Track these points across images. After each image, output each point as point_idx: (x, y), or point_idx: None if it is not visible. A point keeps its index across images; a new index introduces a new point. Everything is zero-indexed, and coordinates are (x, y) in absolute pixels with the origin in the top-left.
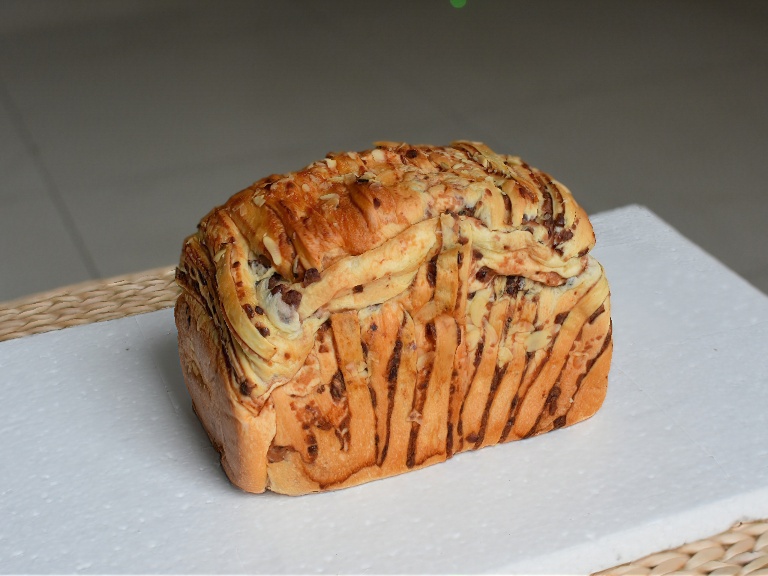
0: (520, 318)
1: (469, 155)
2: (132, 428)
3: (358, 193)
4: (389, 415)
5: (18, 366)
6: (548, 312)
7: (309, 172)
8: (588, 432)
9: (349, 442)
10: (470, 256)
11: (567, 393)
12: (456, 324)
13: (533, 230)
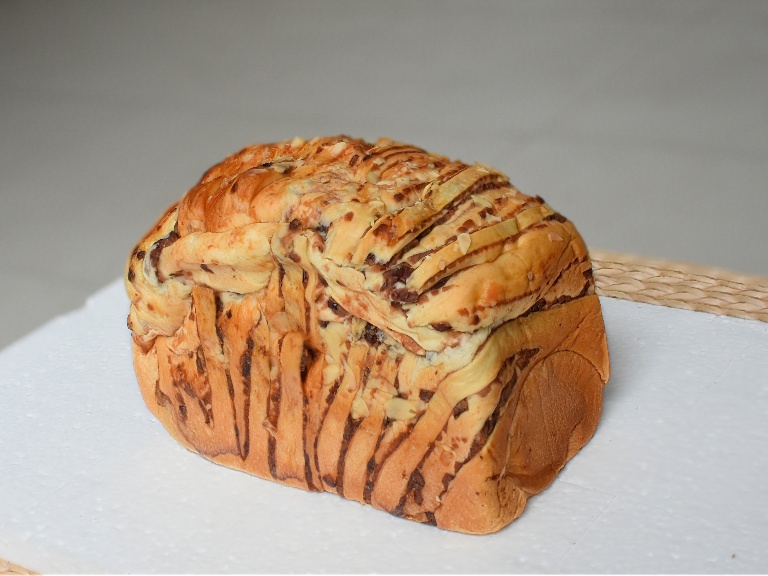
0: (380, 374)
1: None
2: None
3: None
4: (247, 412)
5: None
6: (409, 381)
7: (270, 145)
8: (452, 546)
9: (213, 419)
10: (316, 279)
11: (432, 487)
12: (303, 347)
13: (365, 274)
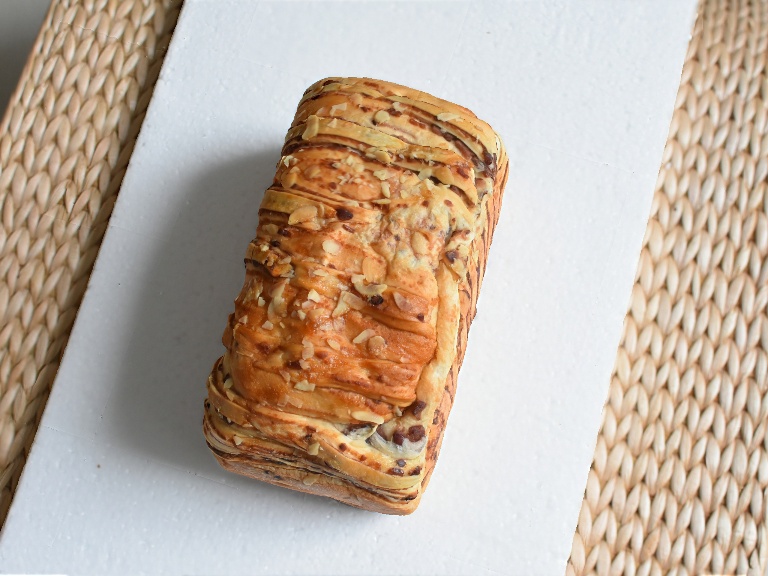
0: None
1: (352, 150)
2: (230, 535)
3: (394, 320)
4: None
5: (48, 572)
6: None
7: (315, 326)
8: (509, 215)
9: None
10: None
11: None
12: (464, 292)
13: None
